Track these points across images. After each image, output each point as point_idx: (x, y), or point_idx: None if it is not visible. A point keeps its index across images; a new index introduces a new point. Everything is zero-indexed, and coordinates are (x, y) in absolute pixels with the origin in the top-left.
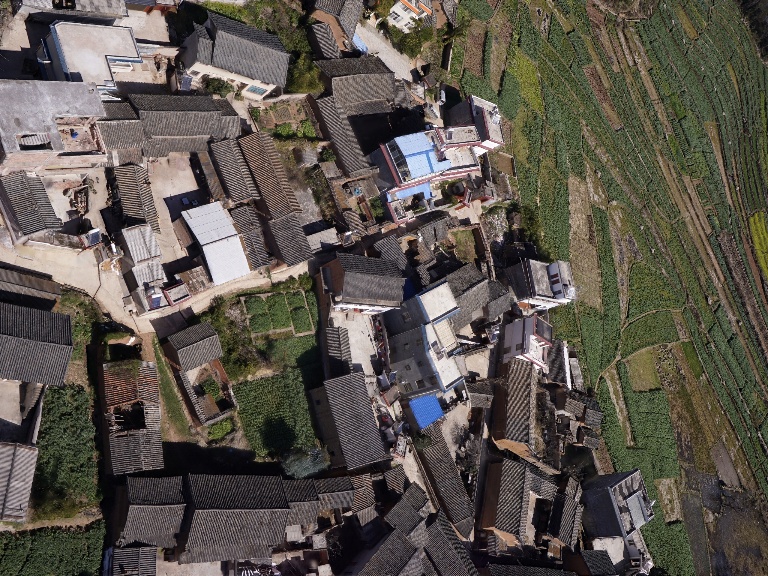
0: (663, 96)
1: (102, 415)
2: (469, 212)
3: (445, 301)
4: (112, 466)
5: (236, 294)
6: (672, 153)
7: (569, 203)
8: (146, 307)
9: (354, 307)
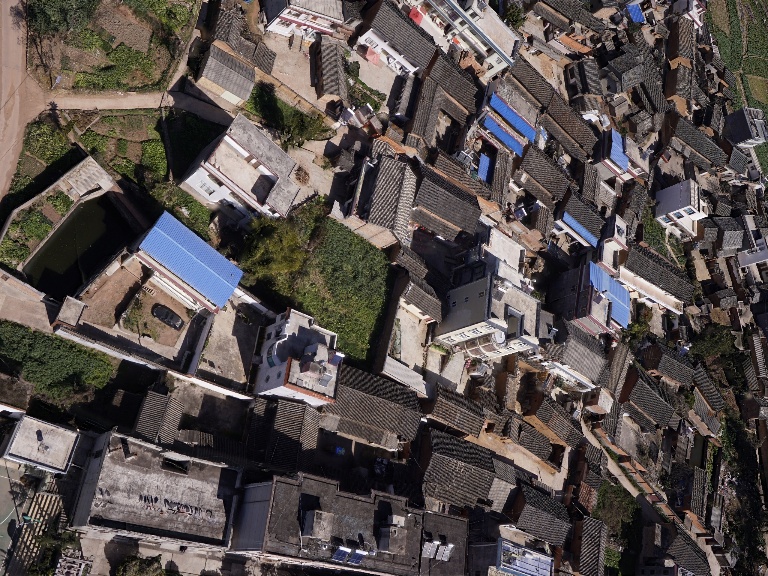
0: None
1: None
2: None
3: None
4: None
5: None
6: None
7: None
8: None
9: None
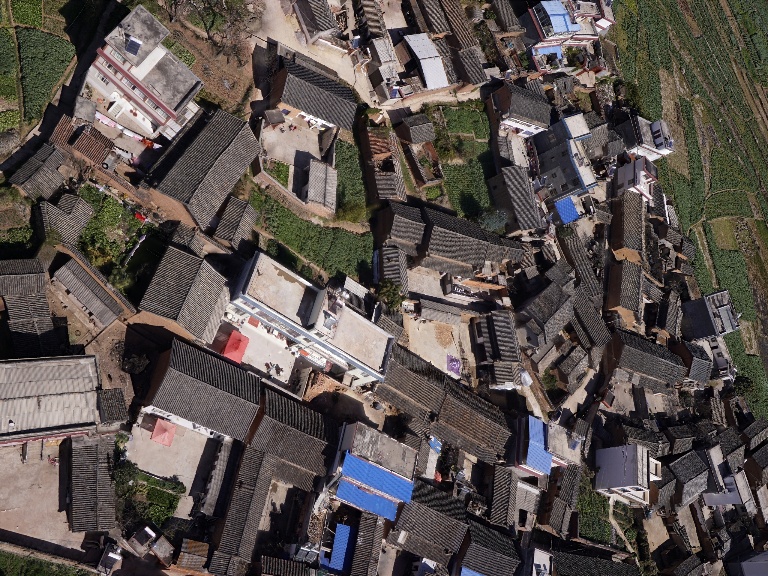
0: (736, 14)
1: (365, 164)
2: (586, 80)
3: (581, 127)
4: (378, 193)
5: (436, 104)
6: (745, 62)
7: (661, 89)
8: (388, 96)
9: (515, 125)
